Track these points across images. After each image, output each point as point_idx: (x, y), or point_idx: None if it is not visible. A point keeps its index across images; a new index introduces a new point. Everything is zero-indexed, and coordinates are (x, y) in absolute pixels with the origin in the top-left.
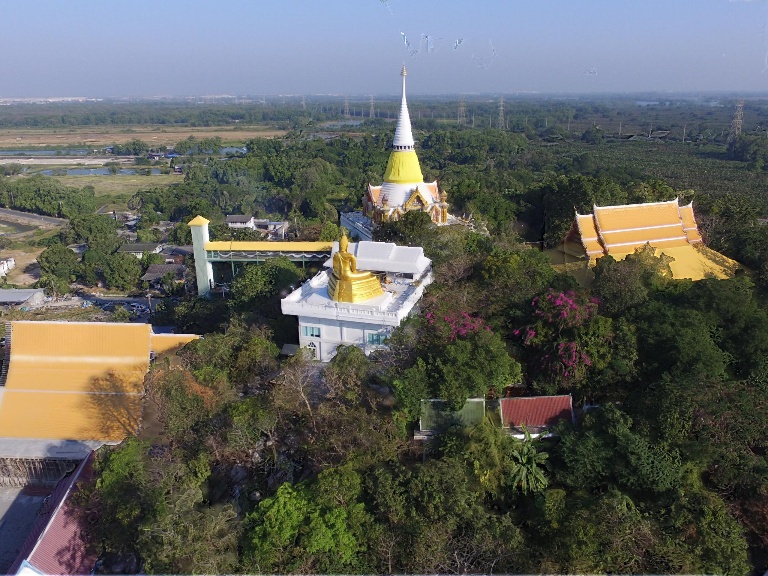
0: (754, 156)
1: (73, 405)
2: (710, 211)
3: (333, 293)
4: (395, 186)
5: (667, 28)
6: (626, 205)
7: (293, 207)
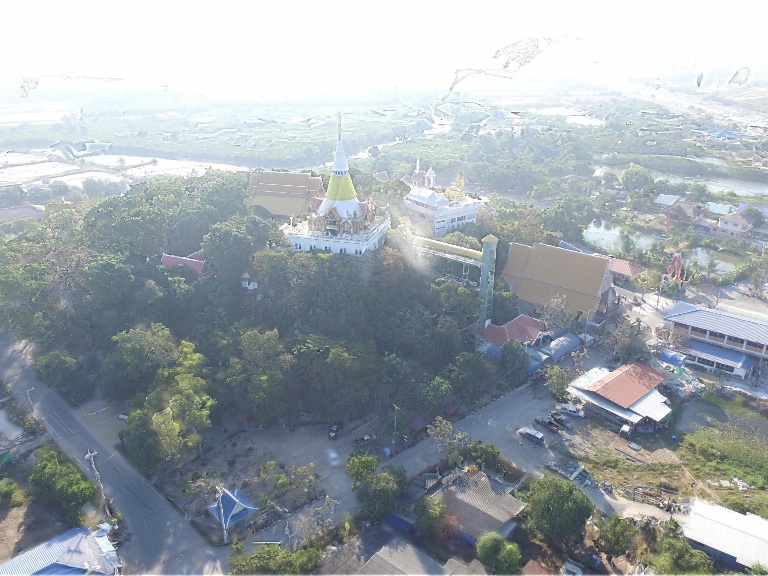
0: None
1: None
2: None
3: None
4: None
5: None
6: None
7: None
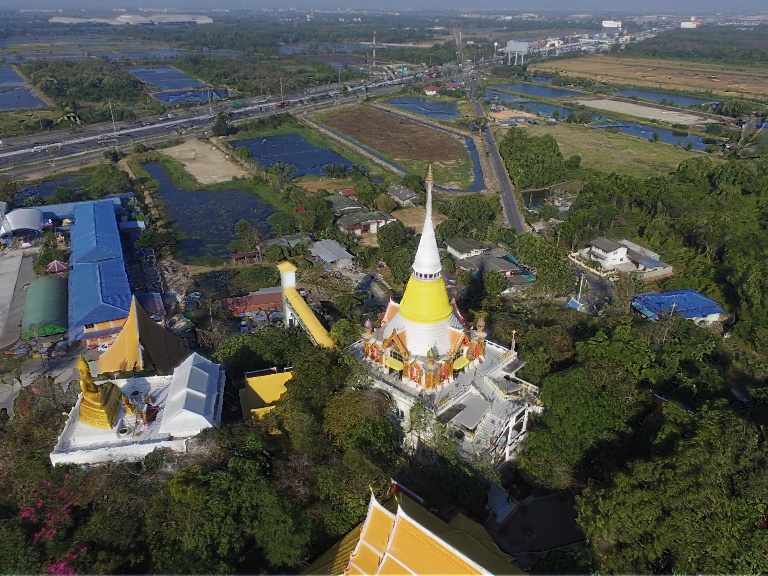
0: None
1: (116, 367)
2: None
3: None
4: (398, 314)
5: None
6: (454, 549)
7: (706, 250)
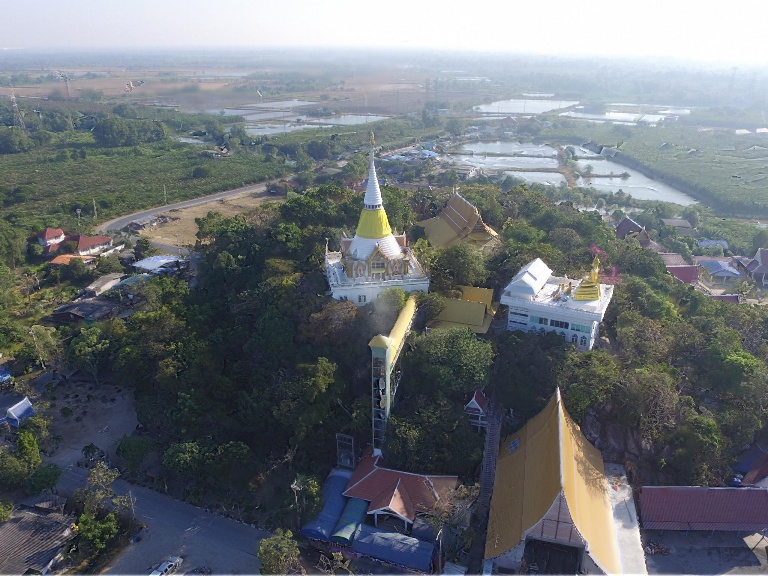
0: (22, 147)
1: (591, 501)
2: (402, 196)
3: (597, 295)
4: (389, 239)
5: (235, 63)
6: None
7: None
